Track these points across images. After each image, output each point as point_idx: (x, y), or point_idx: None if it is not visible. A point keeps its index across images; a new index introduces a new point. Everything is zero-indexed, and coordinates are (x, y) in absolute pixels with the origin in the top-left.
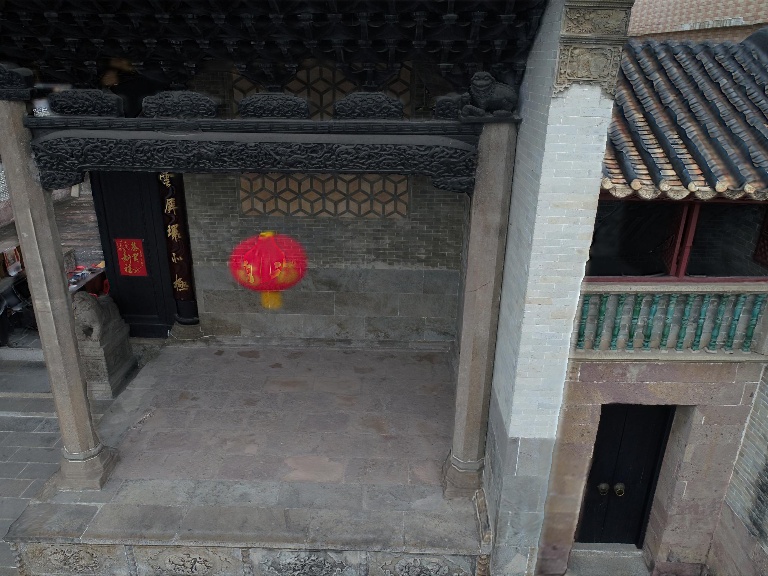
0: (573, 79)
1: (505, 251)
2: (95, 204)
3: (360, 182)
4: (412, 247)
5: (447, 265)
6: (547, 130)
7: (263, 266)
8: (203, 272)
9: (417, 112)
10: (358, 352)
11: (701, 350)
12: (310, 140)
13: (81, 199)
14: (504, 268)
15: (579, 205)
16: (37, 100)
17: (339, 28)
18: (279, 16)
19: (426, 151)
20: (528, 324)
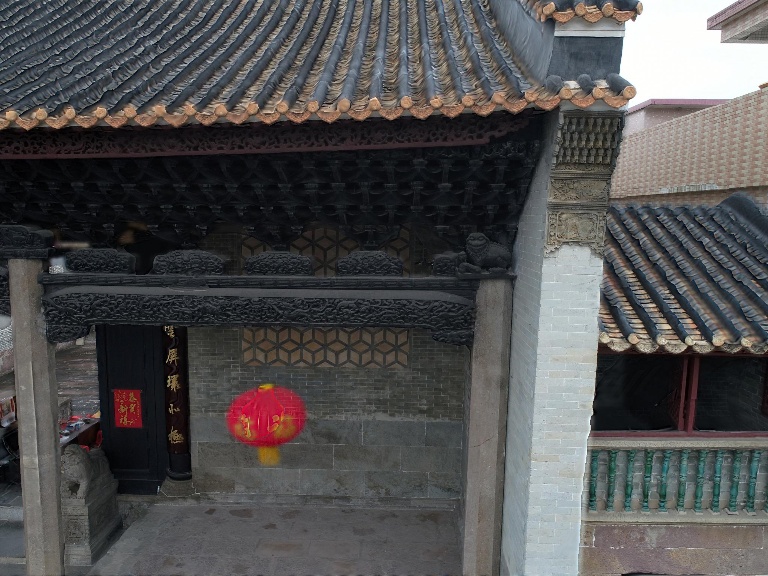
0: (563, 240)
1: (507, 404)
2: (98, 354)
3: (361, 333)
4: (413, 398)
5: (449, 416)
6: (541, 287)
7: (261, 420)
8: (200, 424)
9: (416, 267)
10: (358, 511)
11: (721, 511)
12: (313, 295)
13: (85, 347)
14: (507, 422)
15: (578, 359)
16: (54, 258)
17: (342, 195)
18: (287, 185)
19: (425, 305)
20: (535, 483)
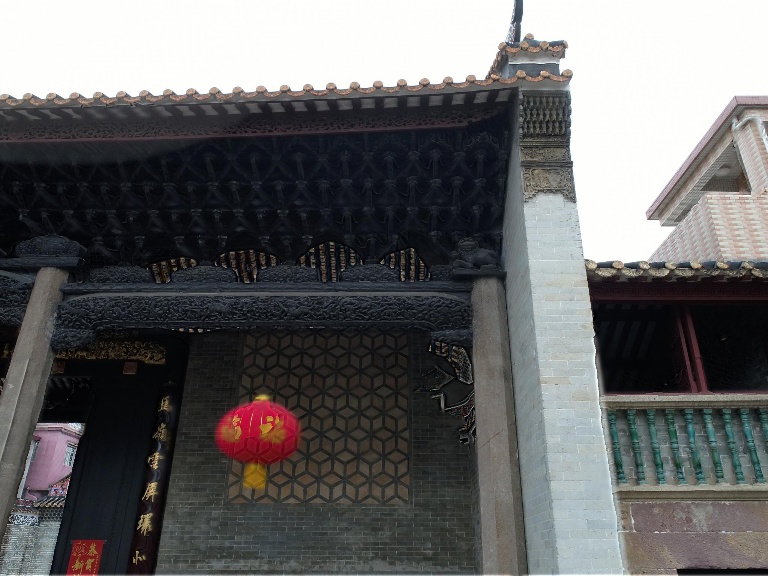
0: (538, 189)
1: (514, 400)
2: (67, 497)
3: (358, 463)
4: (416, 540)
5: (459, 564)
6: (525, 225)
7: (254, 417)
8: None
9: (415, 393)
10: None
11: None
12: (317, 294)
13: None
14: (516, 416)
15: (570, 284)
16: (81, 272)
17: (349, 191)
18: (303, 182)
19: (424, 301)
20: (549, 408)
